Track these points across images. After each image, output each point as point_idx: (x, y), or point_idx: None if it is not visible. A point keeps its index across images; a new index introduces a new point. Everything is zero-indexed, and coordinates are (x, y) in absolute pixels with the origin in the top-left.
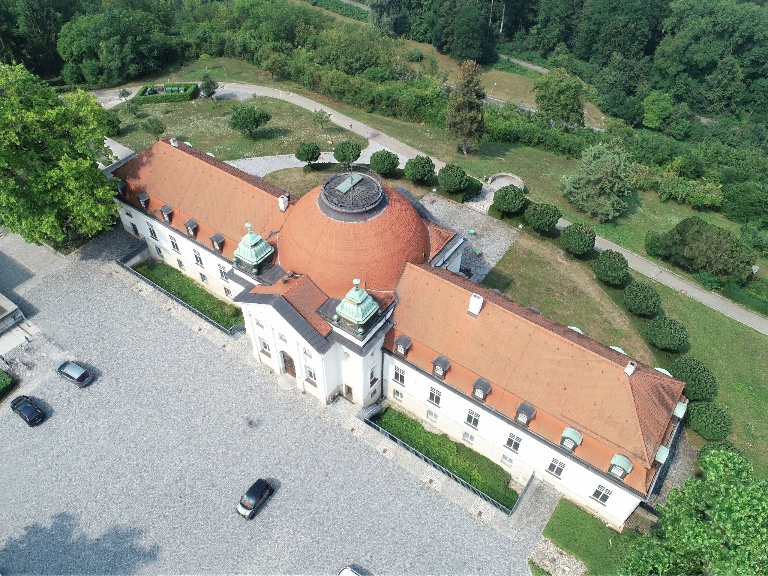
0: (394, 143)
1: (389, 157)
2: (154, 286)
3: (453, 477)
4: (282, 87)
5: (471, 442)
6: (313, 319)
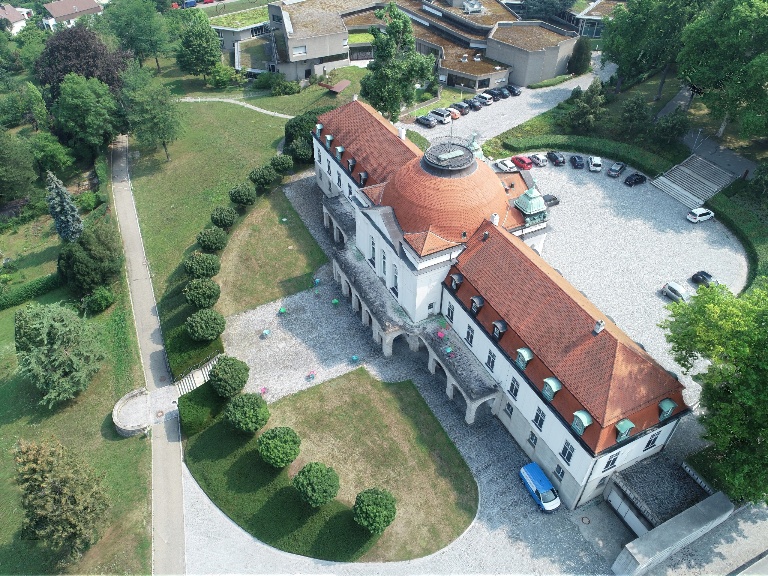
0: None
1: (276, 430)
2: None
3: None
4: None
5: None
6: None
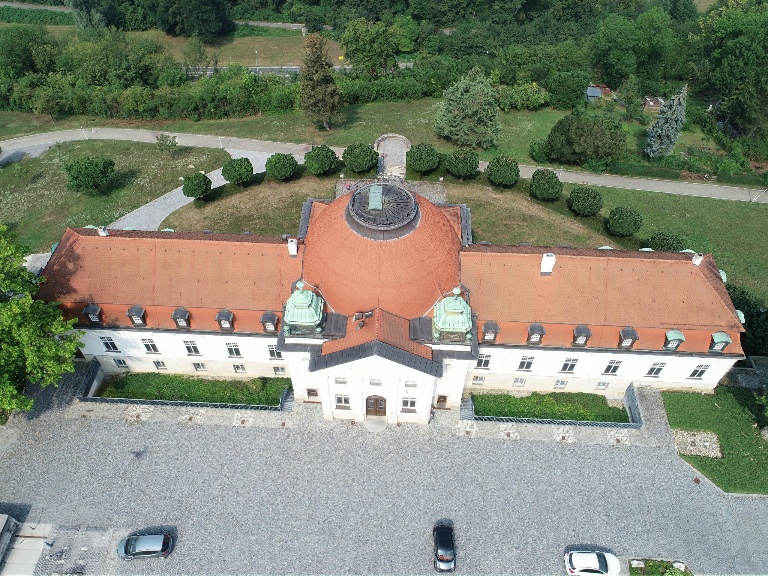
0: (254, 144)
1: (287, 159)
2: (153, 403)
3: (580, 424)
4: (73, 125)
5: (562, 387)
6: (413, 348)
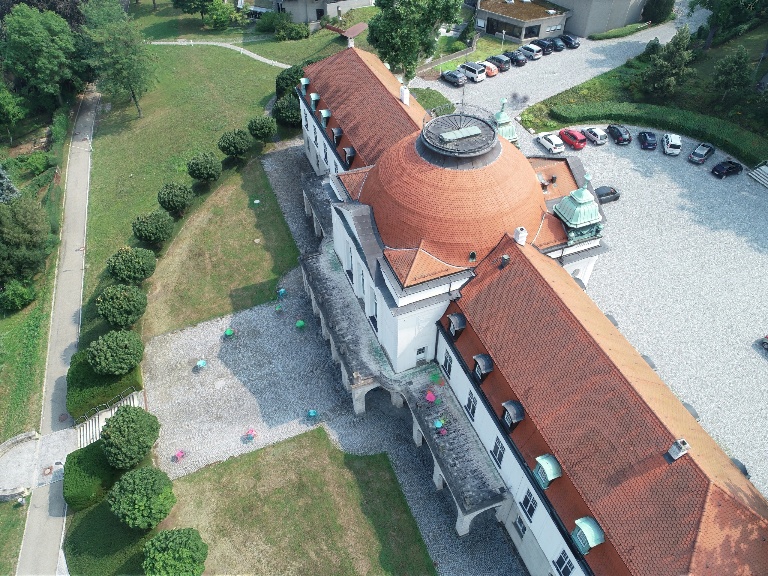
0: None
1: (170, 537)
2: None
3: None
4: None
5: None
6: None
